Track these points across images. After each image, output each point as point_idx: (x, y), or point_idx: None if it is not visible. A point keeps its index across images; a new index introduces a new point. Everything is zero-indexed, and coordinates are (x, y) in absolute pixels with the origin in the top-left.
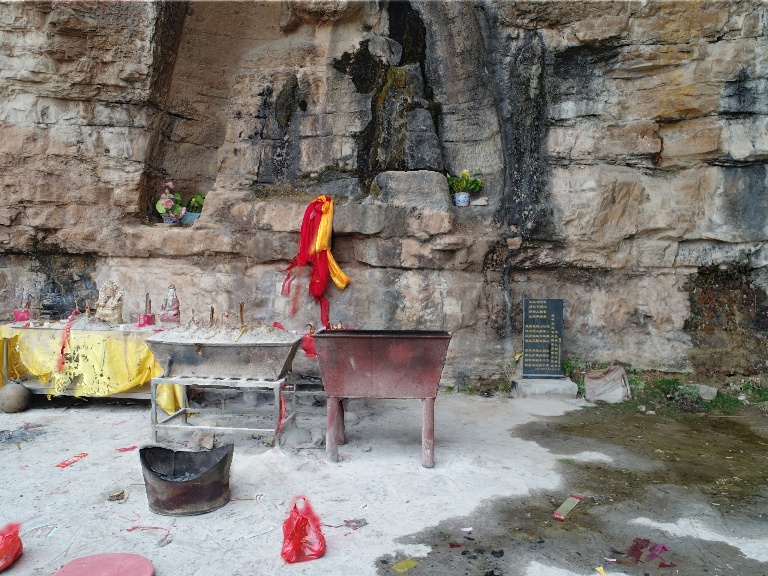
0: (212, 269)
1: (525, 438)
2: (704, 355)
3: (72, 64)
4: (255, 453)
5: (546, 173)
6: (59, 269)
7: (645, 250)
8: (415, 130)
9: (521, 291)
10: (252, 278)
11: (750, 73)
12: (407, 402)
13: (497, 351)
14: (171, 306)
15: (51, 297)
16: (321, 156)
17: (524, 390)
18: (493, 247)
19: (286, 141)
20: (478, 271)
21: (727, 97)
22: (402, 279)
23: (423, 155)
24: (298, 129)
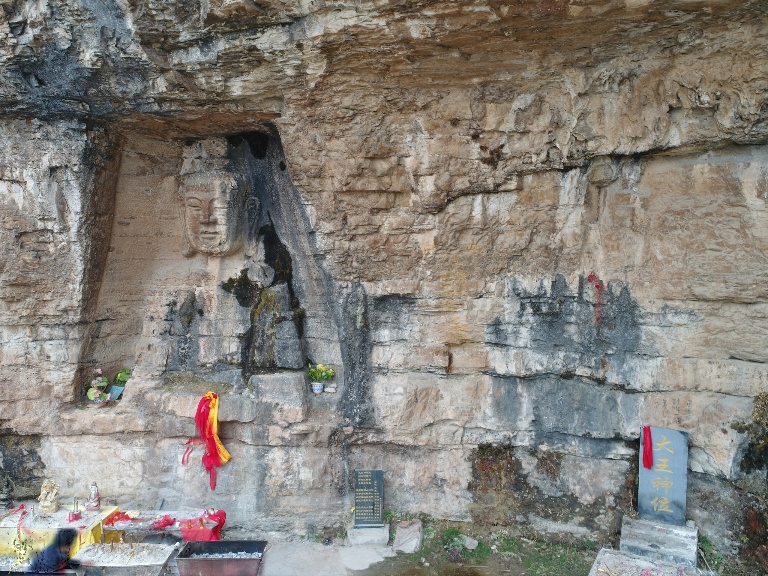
0: (130, 443)
1: None
2: (479, 510)
3: (20, 303)
4: None
5: (371, 379)
6: (12, 446)
7: (441, 433)
8: (282, 338)
9: (356, 461)
10: (161, 450)
11: (502, 320)
12: (266, 555)
13: (338, 506)
14: (93, 499)
15: (6, 492)
16: (214, 351)
17: (351, 541)
18: (334, 432)
19: (188, 338)
20: (325, 447)
21: (489, 334)
22: (270, 454)
23: (287, 358)
24: (197, 329)
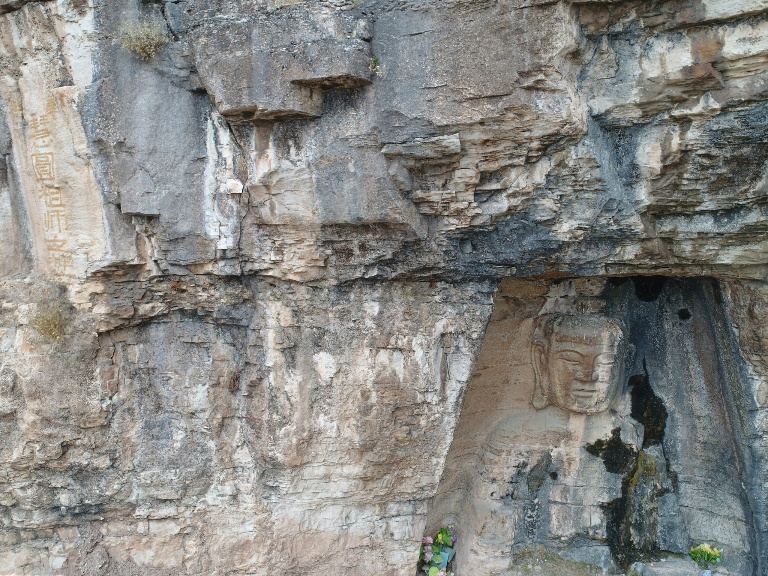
0: None
1: None
2: None
3: (377, 481)
4: None
5: None
6: None
7: None
8: (666, 515)
9: None
10: None
11: None
12: None
13: None
14: None
15: None
16: (571, 523)
17: None
18: None
19: (536, 504)
20: None
21: None
22: None
23: (676, 542)
24: (548, 494)
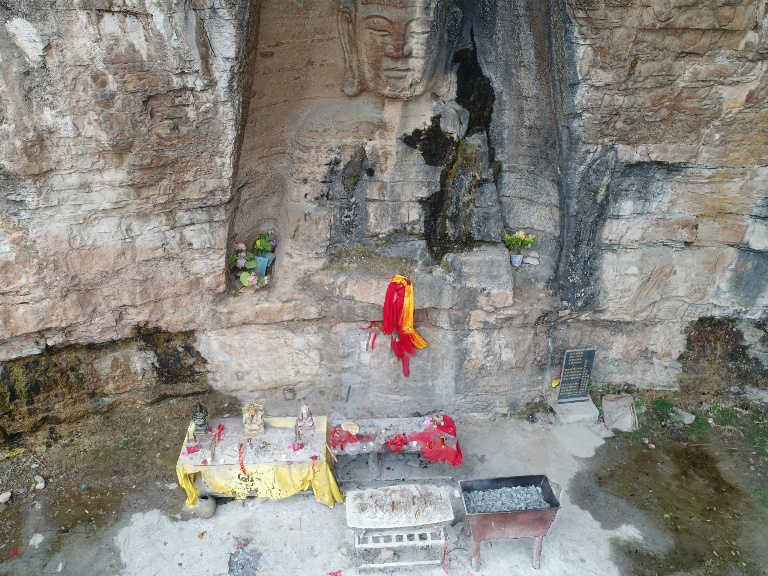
0: (301, 331)
1: (581, 506)
2: (689, 380)
3: (152, 188)
4: (422, 566)
5: (598, 257)
6: (163, 344)
7: (663, 308)
8: (482, 206)
9: (562, 338)
10: (337, 336)
11: None
12: (480, 443)
13: (539, 381)
14: (307, 418)
15: (201, 417)
16: (389, 220)
17: (562, 421)
18: (546, 313)
19: (353, 203)
20: (530, 327)
21: (761, 206)
22: (469, 338)
23: (489, 231)
24: (365, 192)
